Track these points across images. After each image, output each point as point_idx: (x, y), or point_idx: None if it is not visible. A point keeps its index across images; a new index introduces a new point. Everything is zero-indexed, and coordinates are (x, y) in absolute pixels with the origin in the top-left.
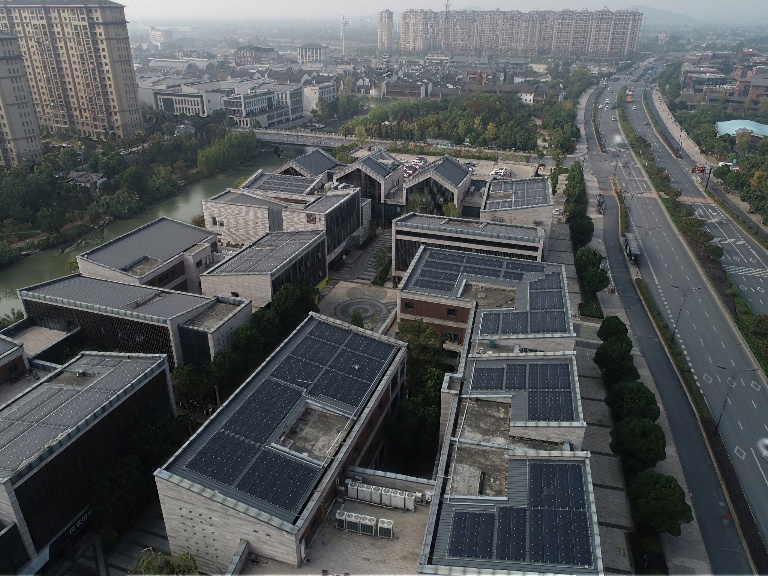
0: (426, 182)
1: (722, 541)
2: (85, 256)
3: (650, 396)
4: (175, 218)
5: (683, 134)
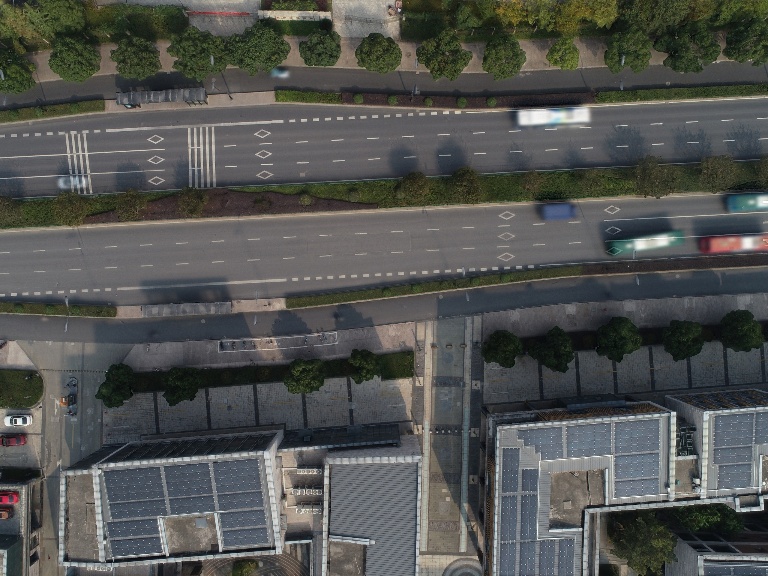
0: None
1: (714, 283)
2: None
3: None
4: None
5: None
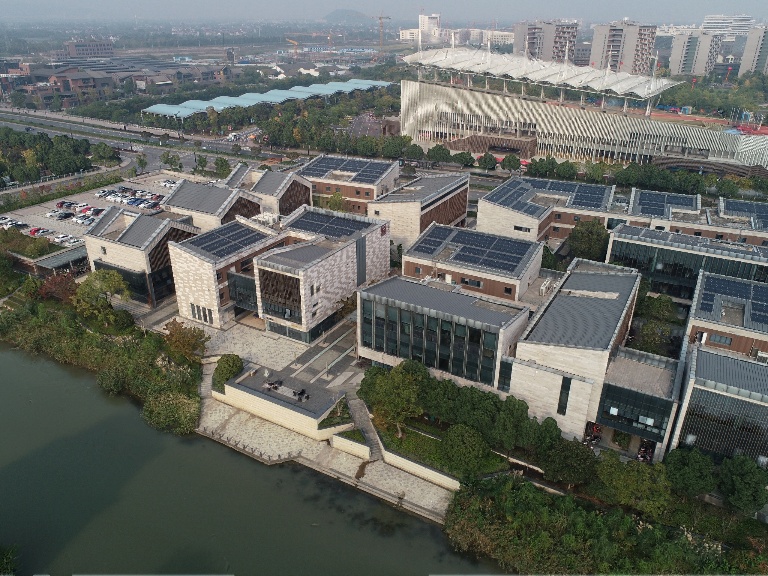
0: (291, 186)
1: None
2: (504, 323)
3: None
4: (2, 416)
5: (127, 126)
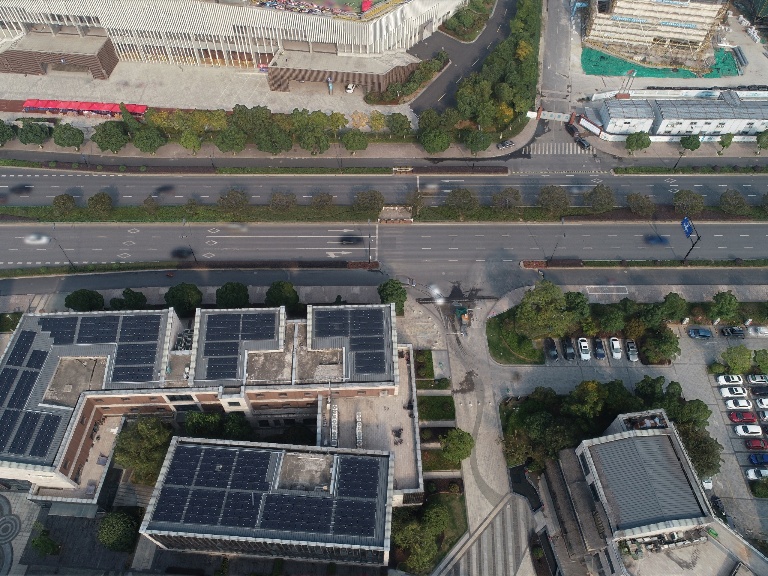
0: None
1: (284, 278)
2: None
3: (186, 285)
4: None
5: None
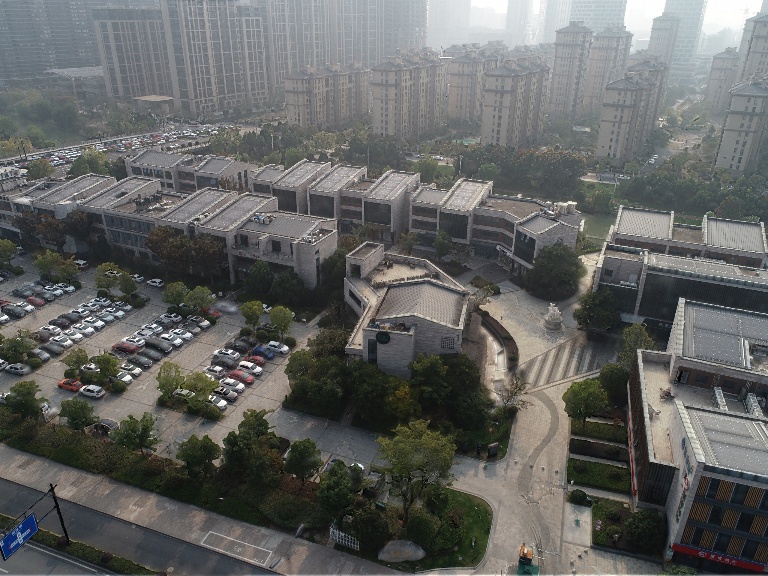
0: None
1: None
2: None
3: None
4: None
5: None
